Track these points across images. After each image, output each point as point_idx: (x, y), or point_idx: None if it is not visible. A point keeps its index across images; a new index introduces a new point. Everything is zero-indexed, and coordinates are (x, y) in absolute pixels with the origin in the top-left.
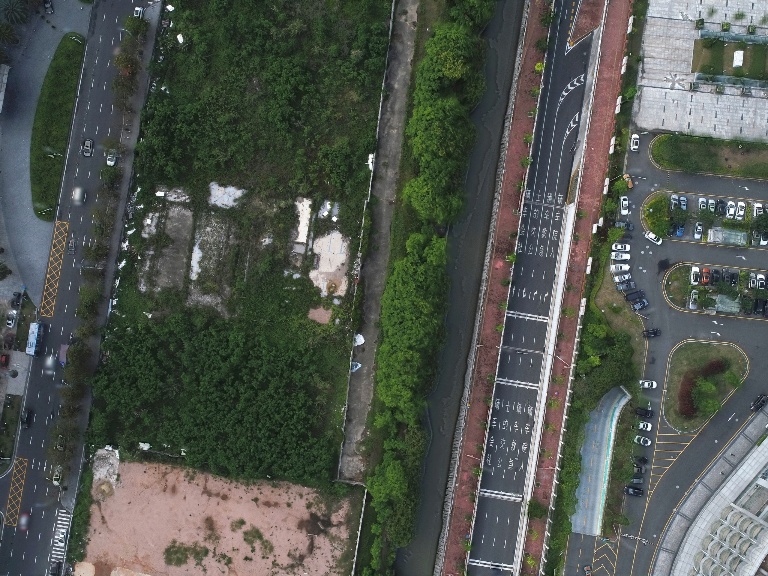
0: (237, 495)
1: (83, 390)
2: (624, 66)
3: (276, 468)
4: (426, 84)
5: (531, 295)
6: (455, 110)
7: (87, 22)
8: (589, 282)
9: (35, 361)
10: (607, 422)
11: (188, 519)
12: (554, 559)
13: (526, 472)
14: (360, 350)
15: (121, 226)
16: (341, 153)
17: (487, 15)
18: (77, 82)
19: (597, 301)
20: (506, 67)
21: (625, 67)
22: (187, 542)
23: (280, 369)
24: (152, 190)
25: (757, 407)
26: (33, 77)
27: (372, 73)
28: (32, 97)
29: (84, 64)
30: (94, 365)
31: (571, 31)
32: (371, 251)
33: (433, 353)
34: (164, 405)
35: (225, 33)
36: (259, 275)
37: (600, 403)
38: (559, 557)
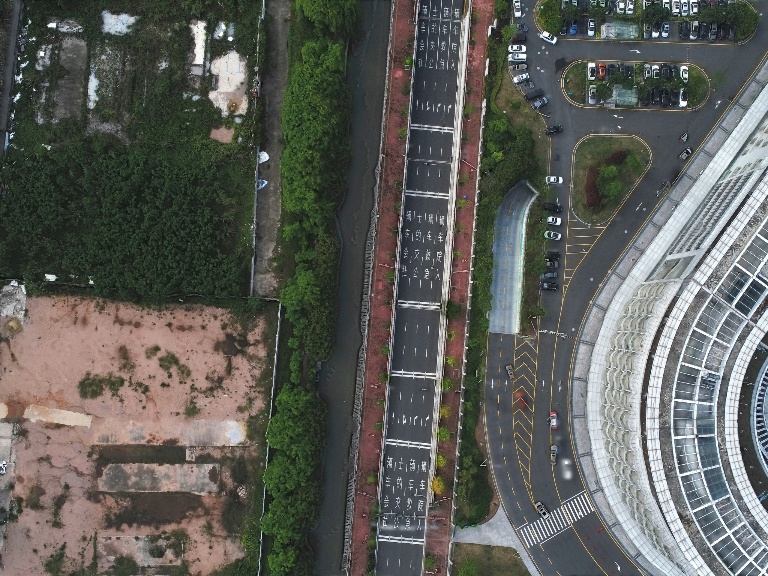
0: (150, 322)
1: None
2: None
3: (185, 284)
4: None
5: (435, 107)
6: None
7: None
8: (488, 84)
9: None
10: (519, 224)
11: (101, 350)
12: (475, 360)
13: (442, 280)
14: (265, 167)
15: (13, 58)
16: None
17: None
18: None
19: (498, 103)
20: None
21: None
22: (101, 373)
23: (183, 187)
24: (43, 21)
25: (662, 193)
26: None
27: None
28: None
29: None
30: None
31: None
32: (269, 69)
33: (337, 161)
34: (68, 233)
35: None
36: (158, 99)
37: (510, 206)
38: (480, 358)
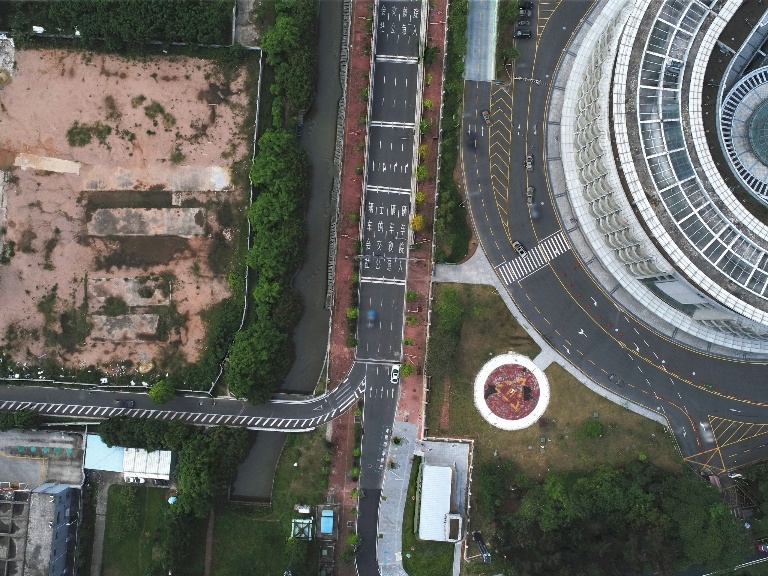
0: (135, 73)
1: None
2: None
3: (168, 28)
4: None
5: None
6: None
7: None
8: None
9: None
10: None
11: (88, 100)
12: (452, 106)
13: (419, 36)
14: None
15: None
16: None
17: None
18: None
19: None
20: None
21: None
22: (89, 122)
23: None
24: None
25: None
26: None
27: None
28: None
29: None
30: None
31: None
32: None
33: None
34: None
35: None
36: None
37: None
38: (456, 103)
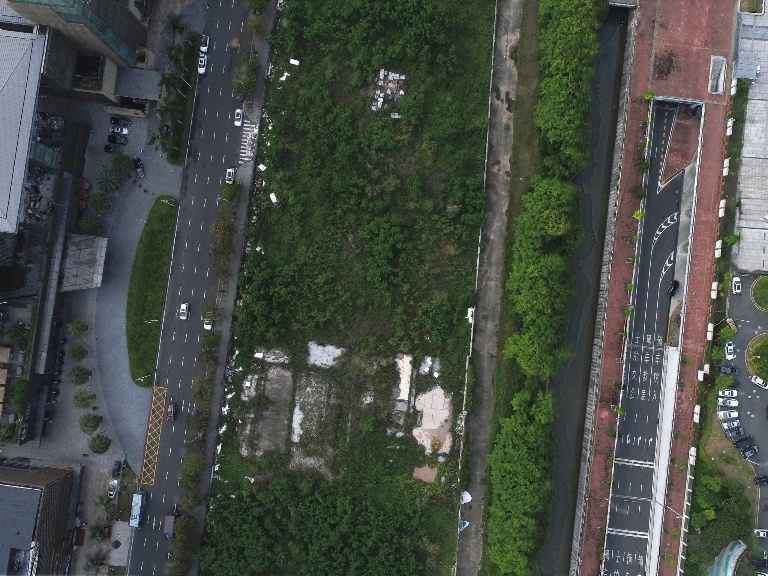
0: None
1: (191, 564)
2: (722, 210)
3: None
4: (528, 241)
5: (635, 441)
6: (556, 264)
7: (178, 184)
8: (697, 430)
9: (138, 531)
10: (721, 571)
11: None
12: None
13: None
14: (467, 508)
15: (221, 391)
16: (442, 310)
17: (582, 163)
18: (171, 245)
19: (706, 449)
20: (600, 210)
21: (724, 211)
22: None
23: (389, 534)
24: (251, 353)
25: None
26: (127, 242)
27: (468, 226)
28: (127, 263)
29: (177, 226)
30: (200, 536)
31: (662, 170)
32: (474, 406)
33: (544, 511)
34: (271, 573)
35: (320, 193)
36: (362, 435)
37: None
38: None
